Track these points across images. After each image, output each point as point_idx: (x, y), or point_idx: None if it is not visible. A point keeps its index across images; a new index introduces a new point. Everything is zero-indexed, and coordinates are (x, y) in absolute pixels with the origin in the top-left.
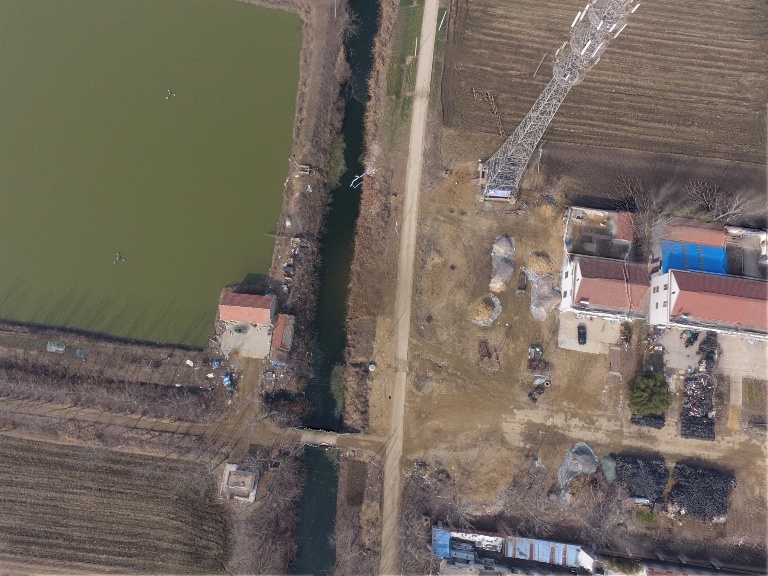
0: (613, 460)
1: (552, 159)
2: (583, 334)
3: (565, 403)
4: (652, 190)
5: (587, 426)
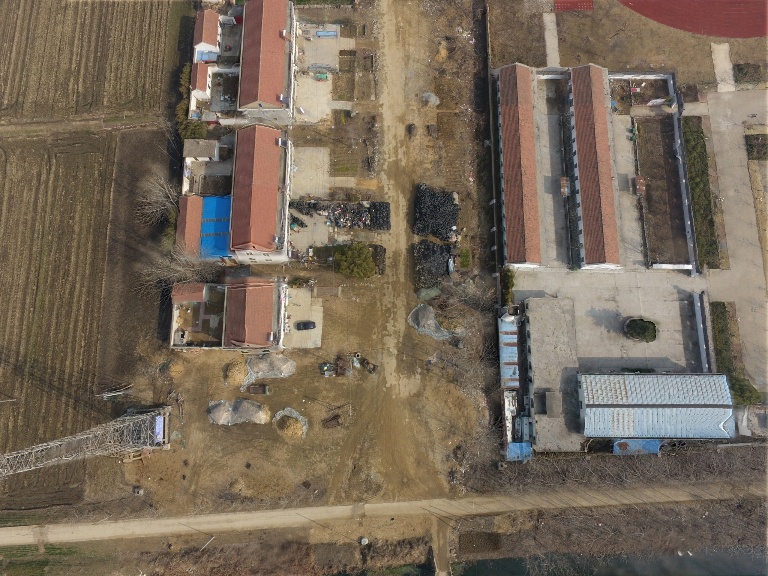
0: (419, 292)
1: (117, 366)
2: (305, 326)
3: (374, 337)
4: (148, 260)
5: (392, 315)
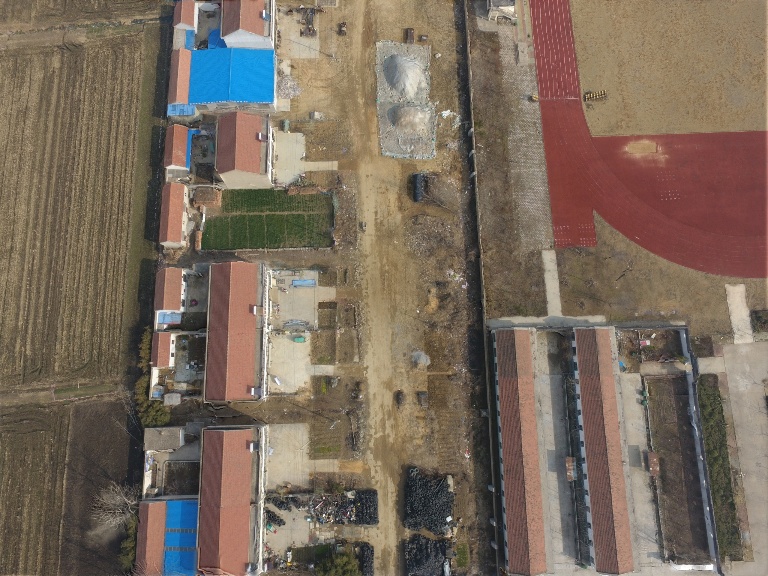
0: None
1: None
2: None
3: None
4: (106, 569)
5: None
